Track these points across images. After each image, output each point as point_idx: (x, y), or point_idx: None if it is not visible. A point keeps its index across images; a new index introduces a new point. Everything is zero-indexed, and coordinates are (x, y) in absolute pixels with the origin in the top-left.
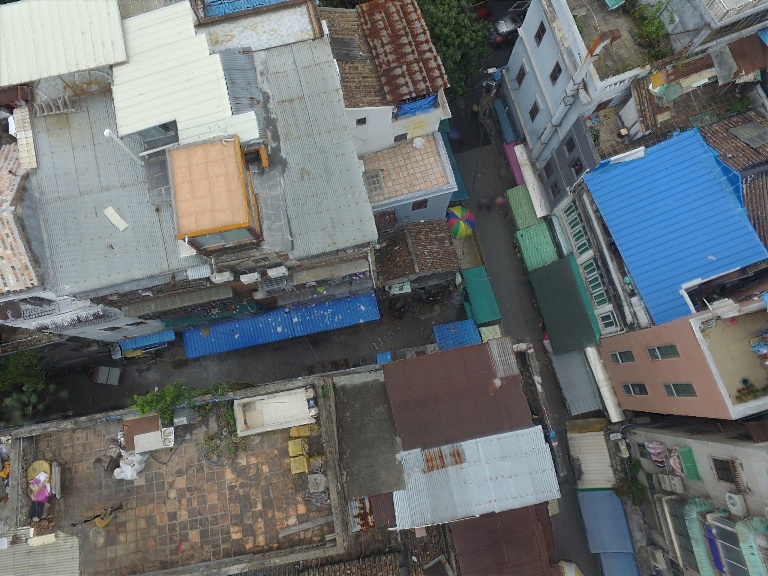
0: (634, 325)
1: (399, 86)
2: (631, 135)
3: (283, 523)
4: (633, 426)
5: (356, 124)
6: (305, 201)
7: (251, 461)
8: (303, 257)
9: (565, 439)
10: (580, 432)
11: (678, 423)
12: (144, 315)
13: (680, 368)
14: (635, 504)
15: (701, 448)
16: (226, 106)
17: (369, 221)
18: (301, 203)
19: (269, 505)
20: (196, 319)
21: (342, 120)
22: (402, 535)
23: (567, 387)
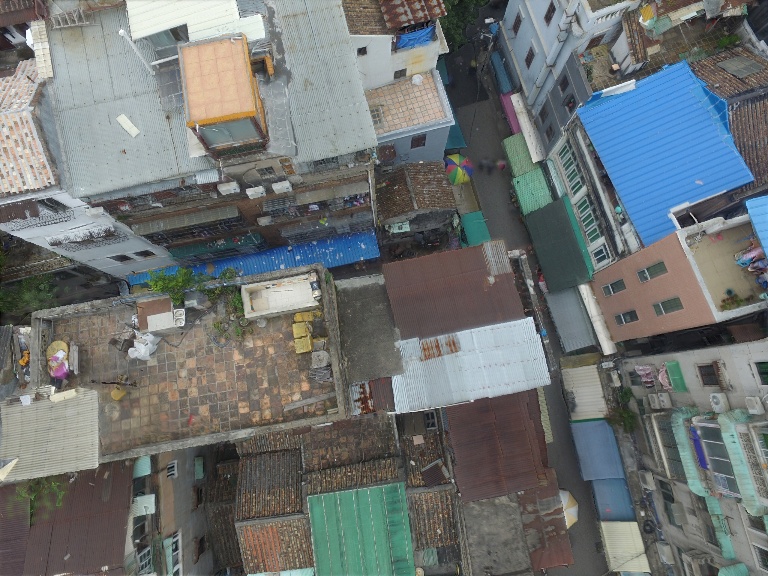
0: (625, 252)
1: (398, 15)
2: (622, 70)
3: (288, 399)
4: (625, 358)
5: (357, 54)
6: (308, 110)
7: (257, 344)
8: (306, 171)
9: (559, 369)
10: (574, 367)
11: (667, 347)
12: (153, 236)
13: (668, 284)
14: (626, 432)
15: (687, 359)
16: (234, 10)
17: (369, 129)
18: (305, 112)
19: (275, 383)
20: (202, 249)
21: (344, 34)
22: (401, 443)
23: (561, 325)
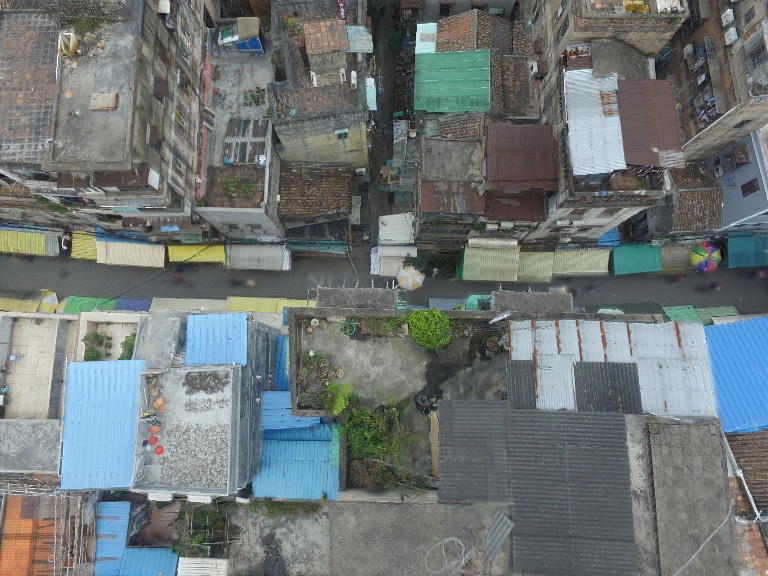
0: None
1: None
2: None
3: None
4: None
5: None
6: None
7: None
8: (746, 50)
9: None
10: None
11: None
12: None
13: None
14: None
15: None
16: None
17: None
18: None
19: None
20: None
21: None
22: None
23: None
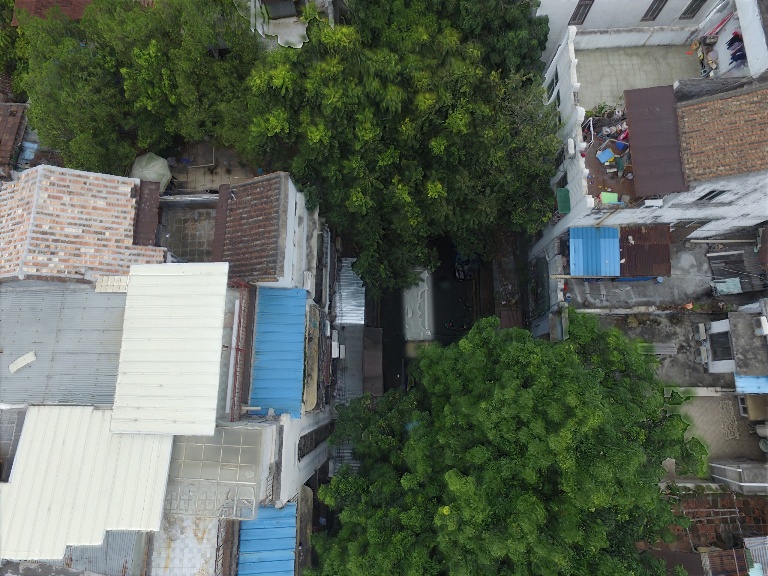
0: None
1: None
2: None
3: None
4: None
5: None
6: None
7: None
8: None
9: None
10: None
11: None
12: None
13: None
14: None
15: None
16: None
17: None
18: None
19: None
20: None
21: None
22: None
23: None
